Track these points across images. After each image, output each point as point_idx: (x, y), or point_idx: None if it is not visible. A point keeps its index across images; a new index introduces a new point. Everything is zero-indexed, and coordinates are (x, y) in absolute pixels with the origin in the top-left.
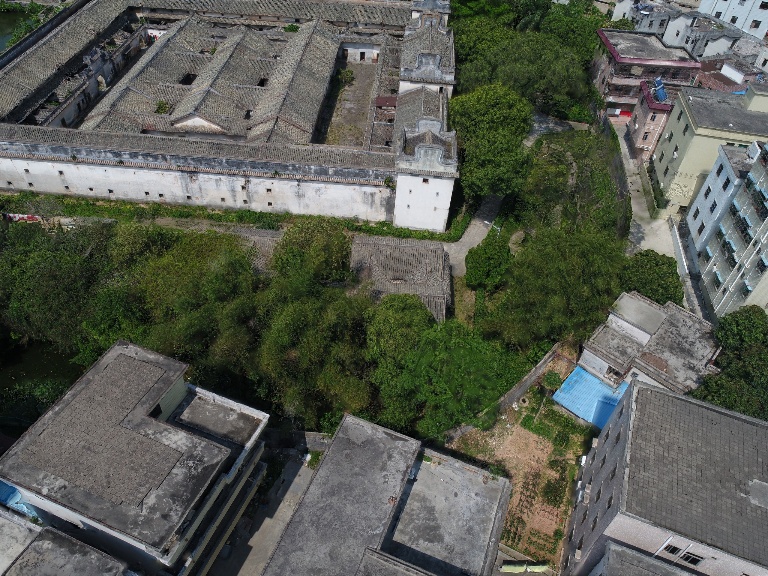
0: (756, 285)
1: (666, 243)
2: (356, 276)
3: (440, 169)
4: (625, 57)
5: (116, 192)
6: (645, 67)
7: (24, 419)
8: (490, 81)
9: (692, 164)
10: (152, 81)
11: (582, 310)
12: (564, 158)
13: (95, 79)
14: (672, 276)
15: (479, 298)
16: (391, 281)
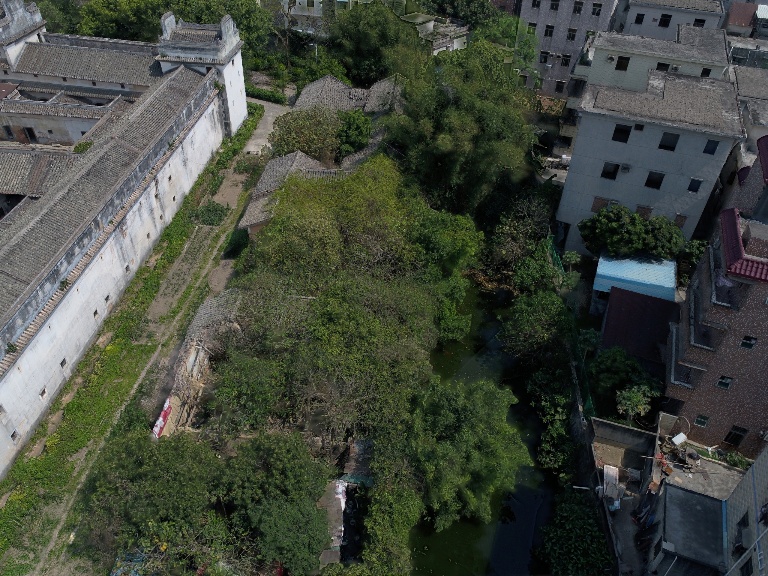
0: None
1: None
2: None
3: (234, 42)
4: None
5: (68, 357)
6: None
7: None
8: None
9: None
10: None
11: None
12: None
13: None
14: None
15: None
16: None
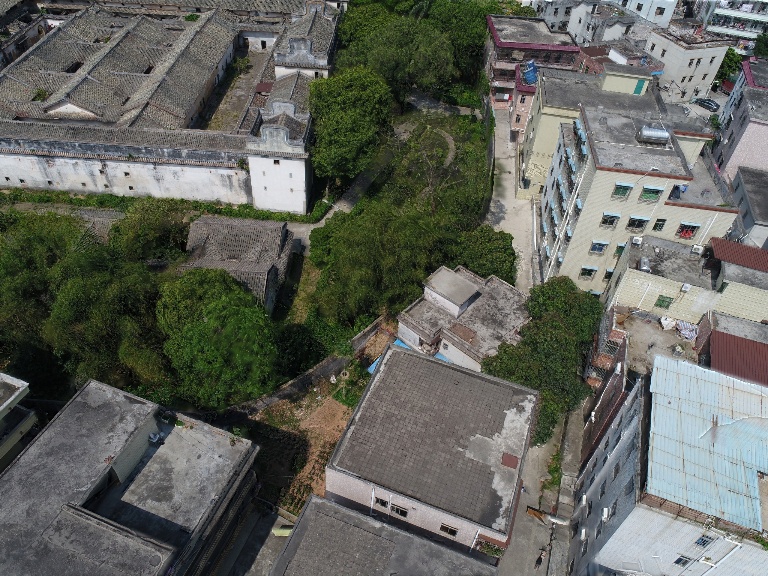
0: (564, 256)
1: (525, 222)
2: (189, 255)
3: (288, 150)
4: (505, 42)
5: None
6: (526, 51)
7: None
8: None
9: (545, 143)
10: (34, 69)
11: (397, 283)
12: (444, 142)
13: None
14: (504, 251)
15: (322, 276)
16: (227, 260)
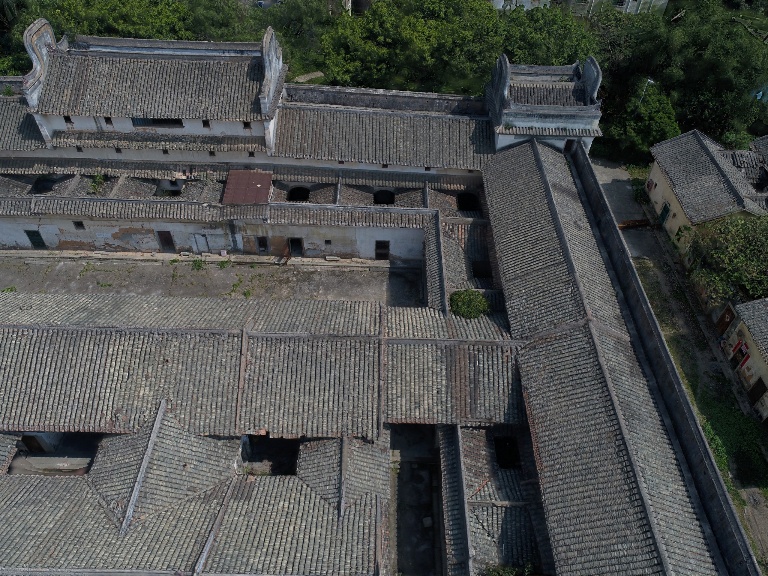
0: None
1: None
2: None
3: None
4: None
5: None
6: None
7: None
8: None
9: None
10: None
11: None
12: None
13: None
14: None
15: None
16: None
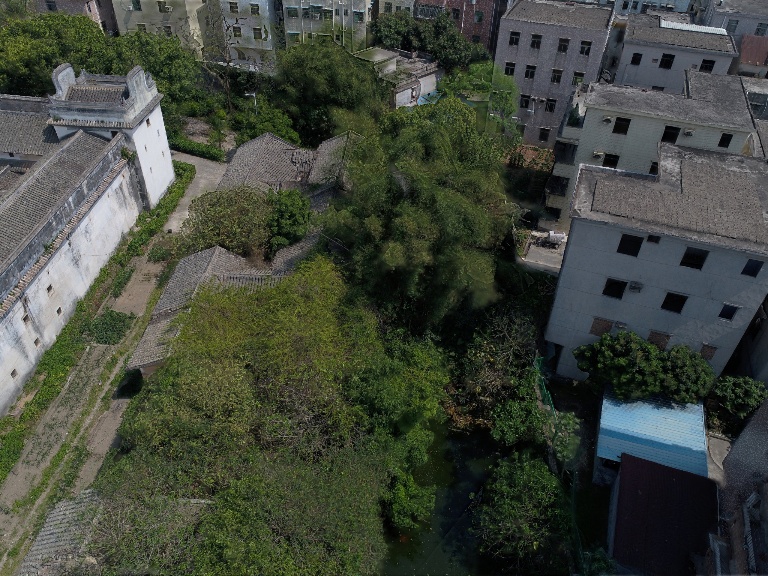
0: (365, 5)
1: None
2: None
3: (149, 97)
4: None
5: None
6: None
7: None
8: None
9: (190, 4)
10: None
11: None
12: None
13: None
14: None
15: None
16: None
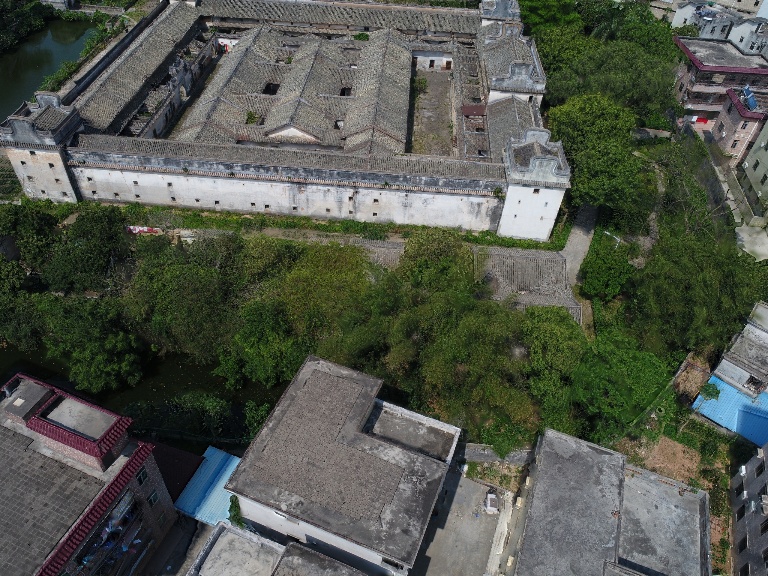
0: None
1: (767, 251)
2: (484, 287)
3: (553, 180)
4: (708, 65)
5: (222, 203)
6: (727, 75)
7: (188, 432)
8: (579, 90)
9: None
10: (238, 91)
11: (720, 320)
12: None
13: (178, 89)
14: None
15: (597, 307)
16: None
